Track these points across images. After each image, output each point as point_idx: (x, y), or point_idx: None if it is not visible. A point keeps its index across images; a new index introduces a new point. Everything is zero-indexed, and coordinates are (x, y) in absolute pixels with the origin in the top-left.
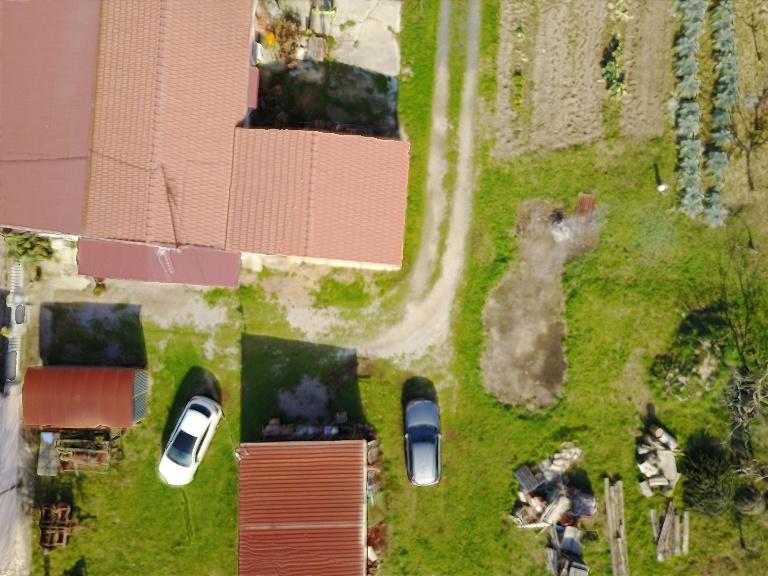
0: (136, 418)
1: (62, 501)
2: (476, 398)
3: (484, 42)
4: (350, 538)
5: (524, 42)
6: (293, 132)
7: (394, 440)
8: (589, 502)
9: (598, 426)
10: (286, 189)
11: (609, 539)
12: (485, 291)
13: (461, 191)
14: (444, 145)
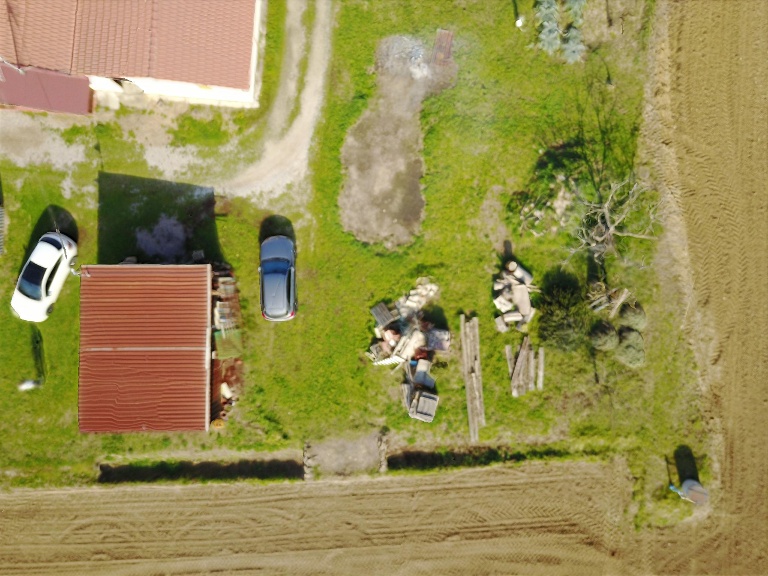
0: None
1: None
2: (333, 236)
3: None
4: (192, 361)
5: None
6: None
7: (251, 279)
8: (441, 335)
9: (455, 263)
10: (130, 10)
11: (464, 375)
12: (343, 128)
13: (319, 28)
14: None
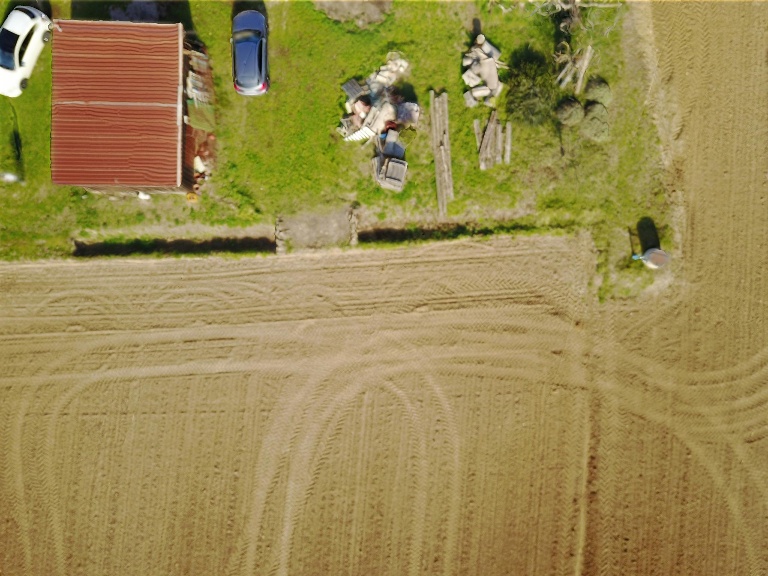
0: None
1: None
2: (305, 14)
3: None
4: (164, 116)
5: None
6: None
7: (224, 57)
8: (410, 105)
9: (425, 41)
10: None
11: (433, 149)
12: None
13: None
14: None
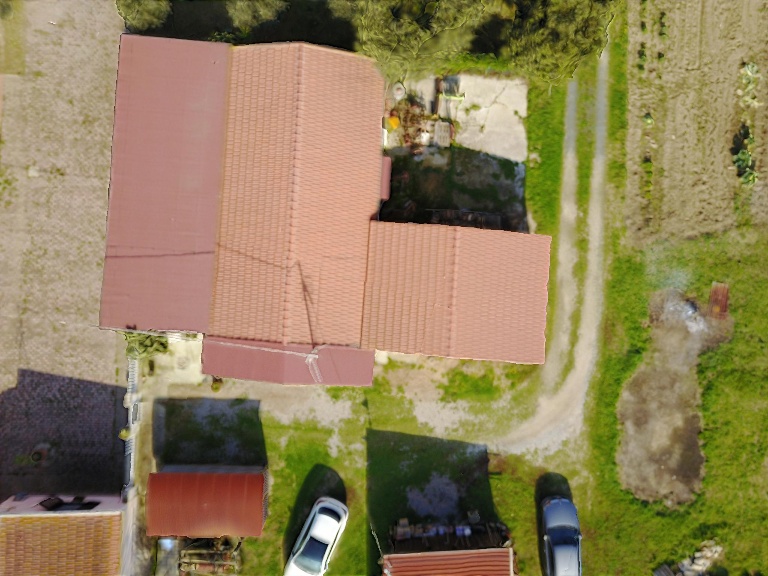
0: (262, 524)
1: None
2: (611, 494)
3: (613, 128)
4: None
5: (653, 128)
6: (434, 227)
7: (527, 539)
8: None
9: (737, 522)
10: (426, 286)
11: None
12: (619, 383)
13: (592, 280)
14: (574, 233)
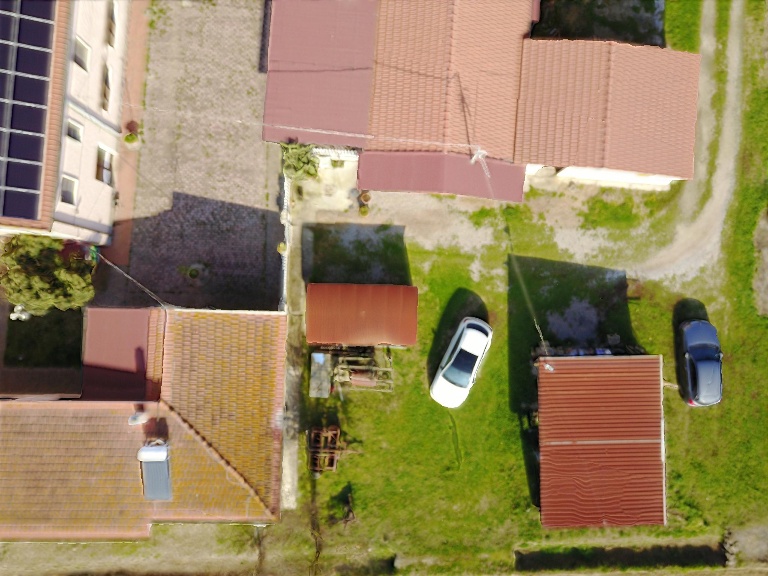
0: None
1: (332, 424)
2: (748, 319)
3: None
4: (650, 453)
5: None
6: (589, 42)
7: (665, 362)
8: None
9: None
10: (580, 100)
11: None
12: (756, 211)
13: (731, 111)
14: (713, 65)
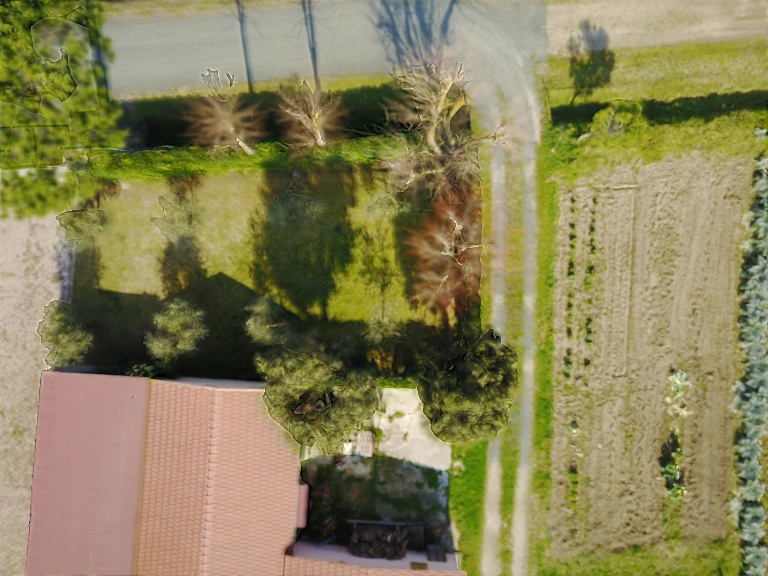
0: None
1: None
2: None
3: (538, 437)
4: None
5: (579, 436)
6: (346, 569)
7: None
8: None
9: None
10: None
11: None
12: None
13: None
14: (498, 543)
